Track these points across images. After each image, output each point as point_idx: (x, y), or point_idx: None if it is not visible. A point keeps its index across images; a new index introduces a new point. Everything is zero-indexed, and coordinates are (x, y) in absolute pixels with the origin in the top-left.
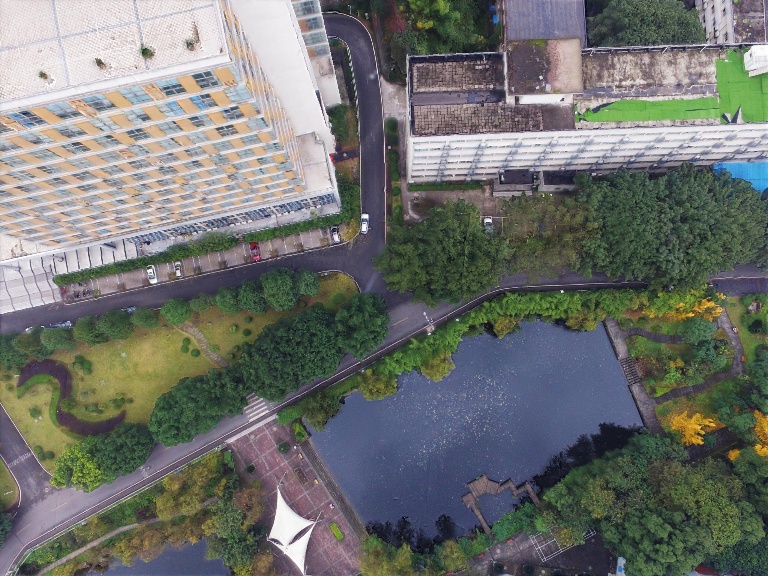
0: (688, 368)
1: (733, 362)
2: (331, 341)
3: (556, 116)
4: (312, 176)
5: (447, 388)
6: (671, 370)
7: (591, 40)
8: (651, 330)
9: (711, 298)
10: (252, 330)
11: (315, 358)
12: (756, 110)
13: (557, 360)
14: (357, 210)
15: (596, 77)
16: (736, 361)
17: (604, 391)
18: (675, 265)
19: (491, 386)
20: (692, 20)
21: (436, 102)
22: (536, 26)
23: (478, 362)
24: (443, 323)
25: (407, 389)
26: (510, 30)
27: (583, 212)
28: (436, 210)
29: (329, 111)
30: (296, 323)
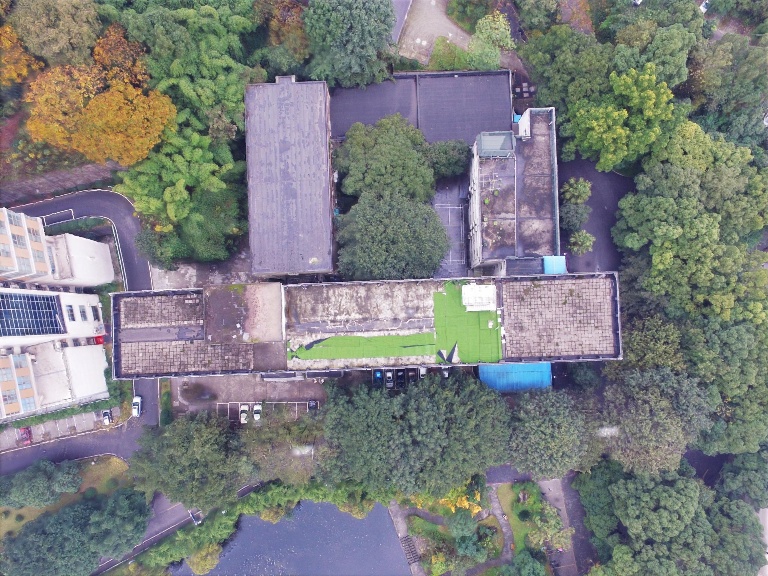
0: (449, 563)
1: (503, 549)
2: (85, 544)
3: (268, 353)
4: (52, 385)
5: (227, 568)
6: (437, 561)
7: (340, 241)
8: (429, 511)
9: (469, 497)
10: (25, 515)
11: (68, 562)
12: (473, 346)
13: (337, 539)
14: (129, 393)
15: (310, 311)
16: (506, 548)
17: (384, 570)
18: (408, 488)
19: (271, 566)
20: (425, 237)
21: (145, 338)
22: (280, 229)
23: (258, 541)
24: (215, 510)
25: (186, 569)
26: (253, 233)
27: (318, 432)
28: (163, 435)
29: (100, 290)
30: (50, 526)
